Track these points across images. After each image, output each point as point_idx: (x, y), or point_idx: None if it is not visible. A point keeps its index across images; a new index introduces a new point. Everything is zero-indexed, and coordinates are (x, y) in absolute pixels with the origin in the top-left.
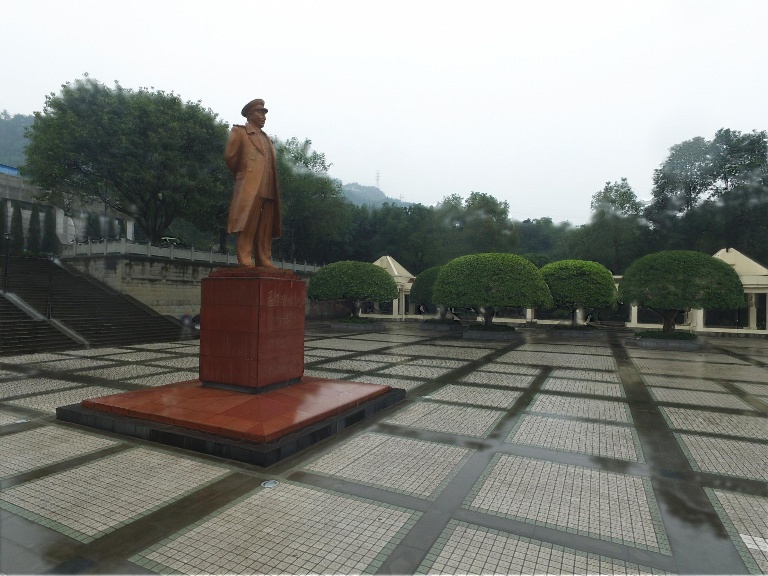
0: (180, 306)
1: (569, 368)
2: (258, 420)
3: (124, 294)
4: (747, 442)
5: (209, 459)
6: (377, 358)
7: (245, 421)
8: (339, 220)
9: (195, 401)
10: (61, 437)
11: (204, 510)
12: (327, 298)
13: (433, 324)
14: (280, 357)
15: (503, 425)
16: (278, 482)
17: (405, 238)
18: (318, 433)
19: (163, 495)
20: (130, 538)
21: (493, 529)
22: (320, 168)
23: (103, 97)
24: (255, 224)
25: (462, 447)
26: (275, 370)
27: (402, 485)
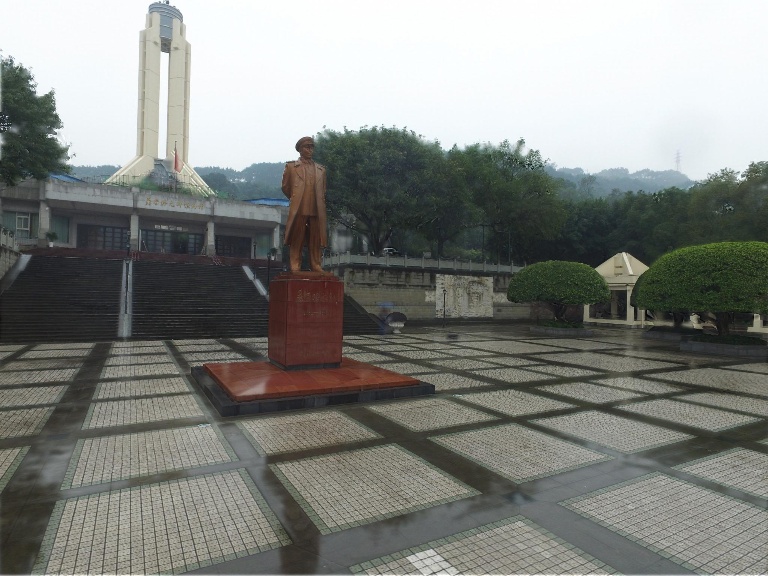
0: (395, 306)
1: (738, 393)
2: (252, 386)
3: (348, 296)
4: (748, 504)
5: (208, 407)
6: (504, 360)
7: (245, 386)
8: (548, 218)
9: (247, 371)
10: (173, 383)
11: (148, 429)
12: (522, 300)
13: (660, 332)
14: (312, 344)
15: (463, 427)
16: (209, 425)
17: (649, 230)
18: (288, 403)
19: (149, 418)
20: (98, 432)
21: (252, 480)
22: (536, 166)
23: (333, 142)
24: (300, 237)
25: (377, 433)
26: (306, 354)
27: (268, 444)
